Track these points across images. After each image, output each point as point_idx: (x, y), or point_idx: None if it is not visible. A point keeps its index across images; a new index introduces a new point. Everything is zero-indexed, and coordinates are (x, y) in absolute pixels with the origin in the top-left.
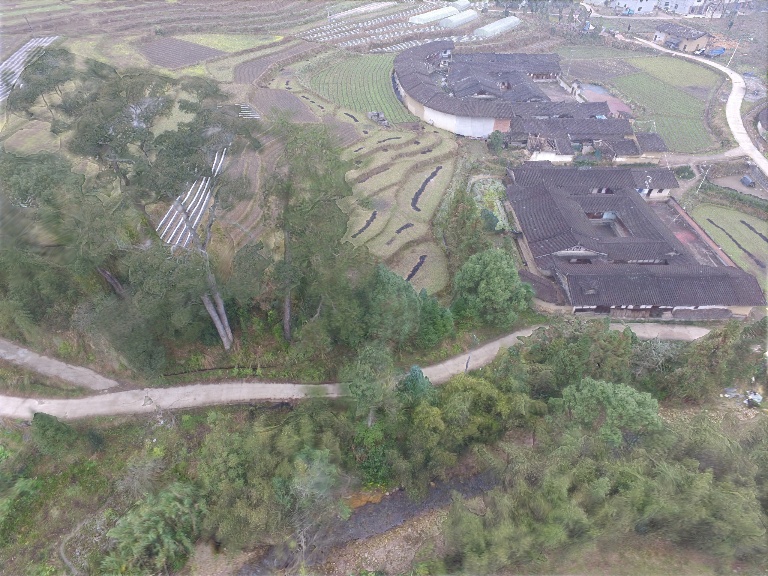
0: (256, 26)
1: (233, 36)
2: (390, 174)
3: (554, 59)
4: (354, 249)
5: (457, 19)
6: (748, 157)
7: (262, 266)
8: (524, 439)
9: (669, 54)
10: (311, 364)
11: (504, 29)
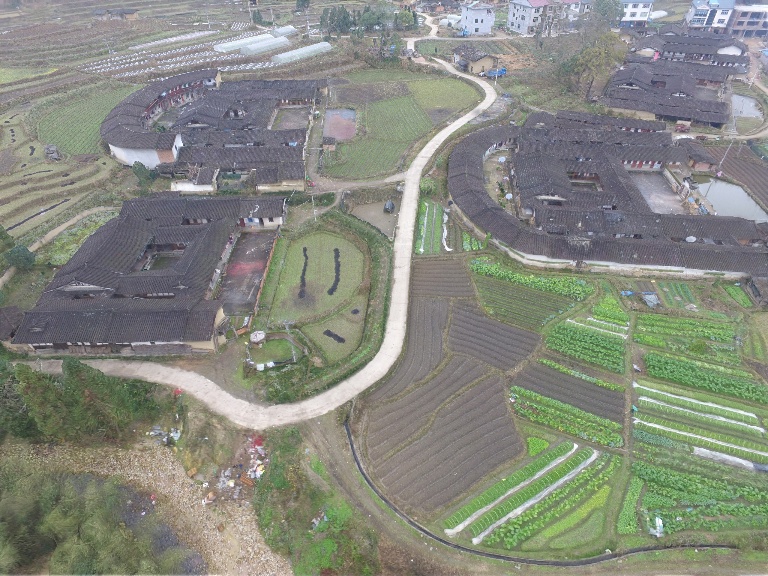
0: (38, 60)
1: (12, 70)
2: (3, 208)
3: (321, 85)
4: None
5: (257, 47)
6: None
7: None
8: None
9: (455, 76)
10: None
11: (307, 55)
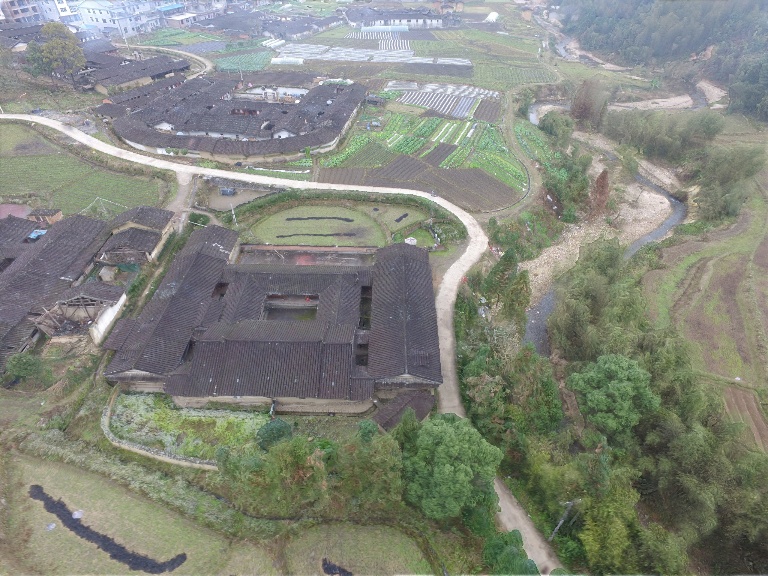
0: None
1: None
2: None
3: None
4: None
5: None
6: (198, 175)
7: None
8: None
9: None
10: None
11: None
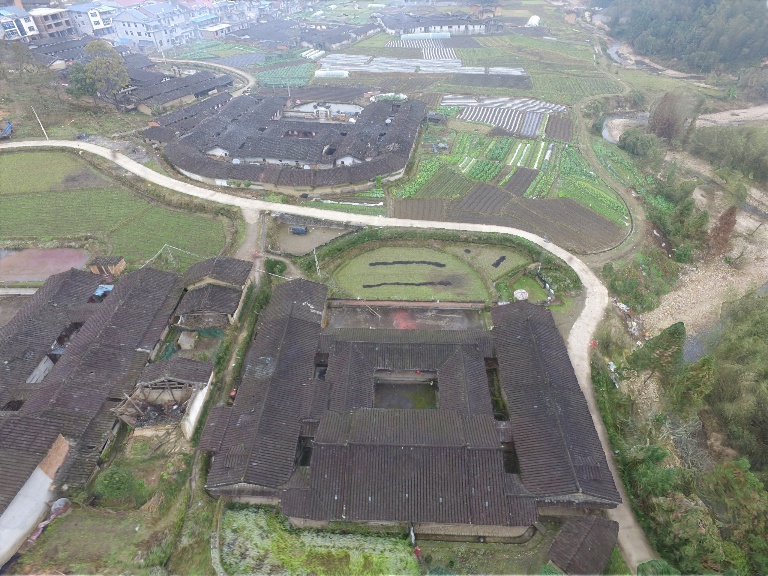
0: None
1: None
2: None
3: None
4: None
5: None
6: (266, 211)
7: None
8: None
9: None
10: None
11: None
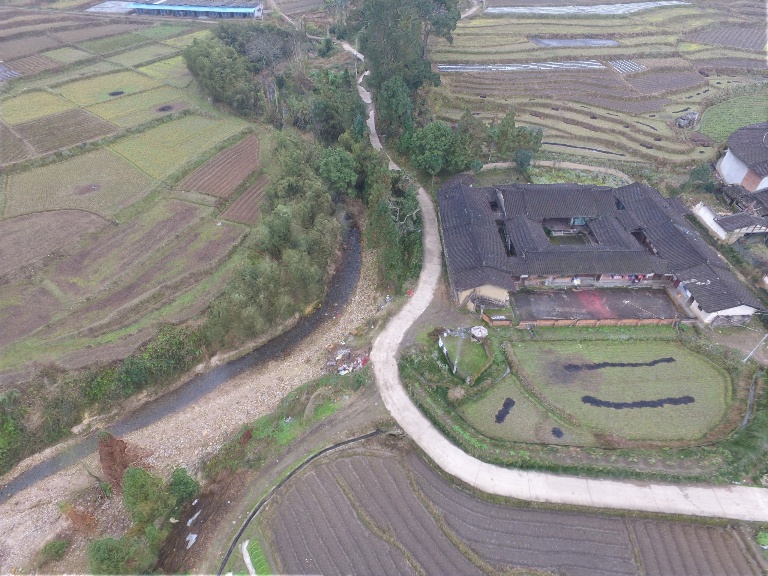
0: None
1: None
2: (587, 132)
3: None
4: (413, 73)
5: None
6: None
7: (356, 27)
8: (357, 206)
9: None
10: (382, 120)
11: None
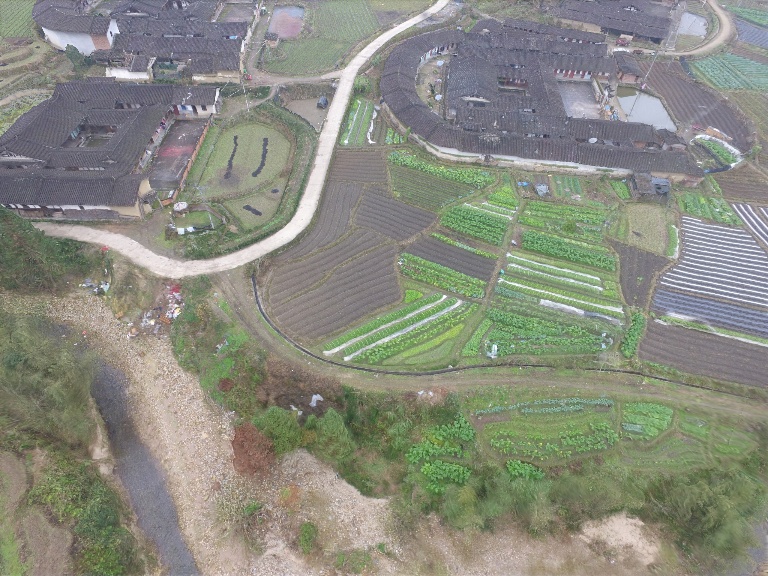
0: None
1: None
2: None
3: None
4: None
5: None
6: (336, 79)
7: None
8: None
9: None
10: None
11: None
